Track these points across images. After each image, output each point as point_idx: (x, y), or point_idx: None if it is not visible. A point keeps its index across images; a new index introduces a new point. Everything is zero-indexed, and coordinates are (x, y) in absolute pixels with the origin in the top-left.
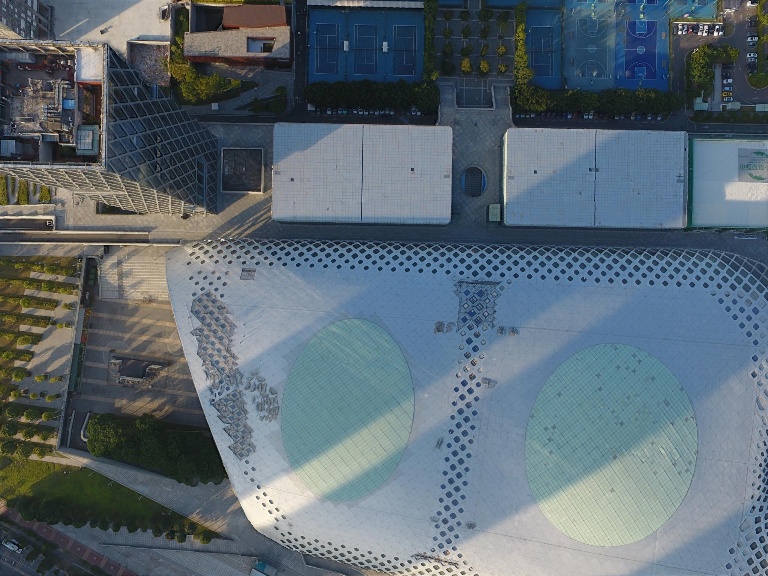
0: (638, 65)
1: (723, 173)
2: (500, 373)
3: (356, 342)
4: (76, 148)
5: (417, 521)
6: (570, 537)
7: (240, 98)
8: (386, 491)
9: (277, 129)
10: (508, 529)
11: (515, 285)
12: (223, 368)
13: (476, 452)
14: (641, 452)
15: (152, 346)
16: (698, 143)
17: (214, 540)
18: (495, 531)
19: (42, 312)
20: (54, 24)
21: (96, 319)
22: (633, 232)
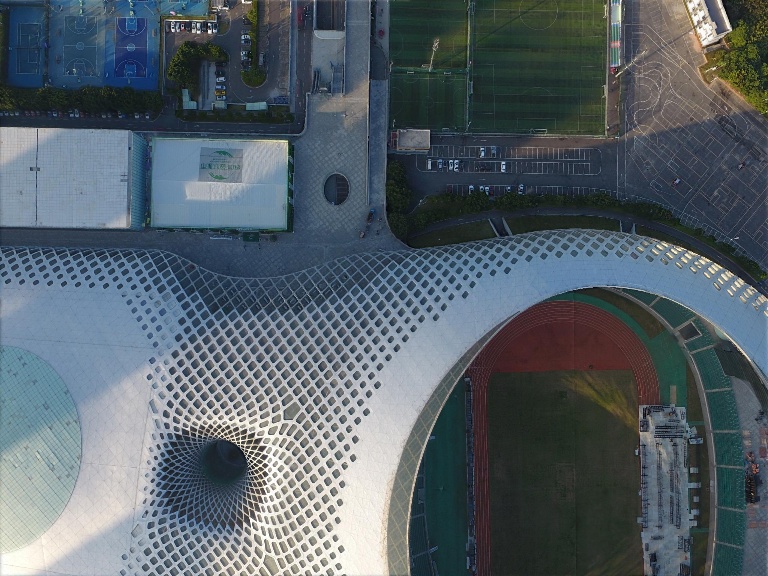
0: (128, 63)
1: (184, 172)
2: None
3: None
4: None
5: None
6: None
7: None
8: None
9: None
10: None
11: None
12: None
13: None
14: (14, 457)
15: None
16: (160, 142)
17: None
18: None
19: None
20: None
21: None
22: (106, 232)
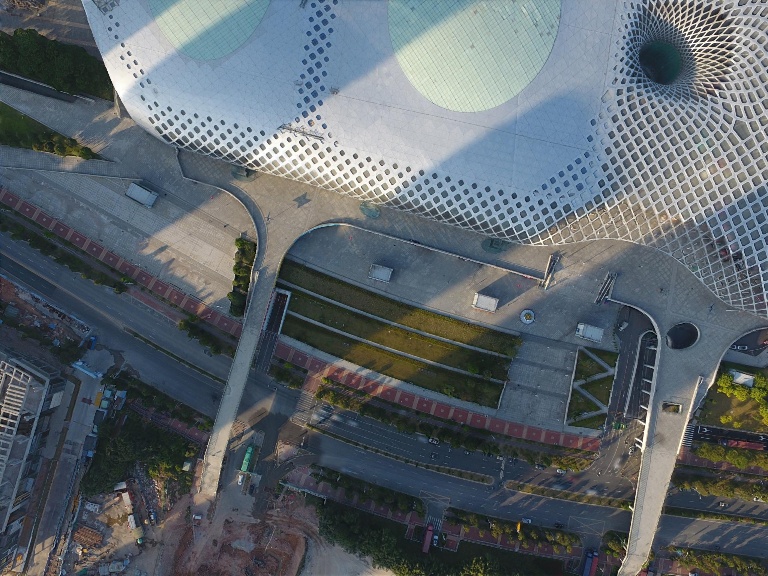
0: None
1: None
2: None
3: None
4: None
5: (281, 85)
6: (432, 102)
7: None
8: (249, 50)
9: None
10: (371, 94)
11: None
12: None
13: (340, 13)
14: (502, 9)
15: None
16: None
17: (96, 163)
18: (358, 97)
19: None
20: None
21: None
22: None
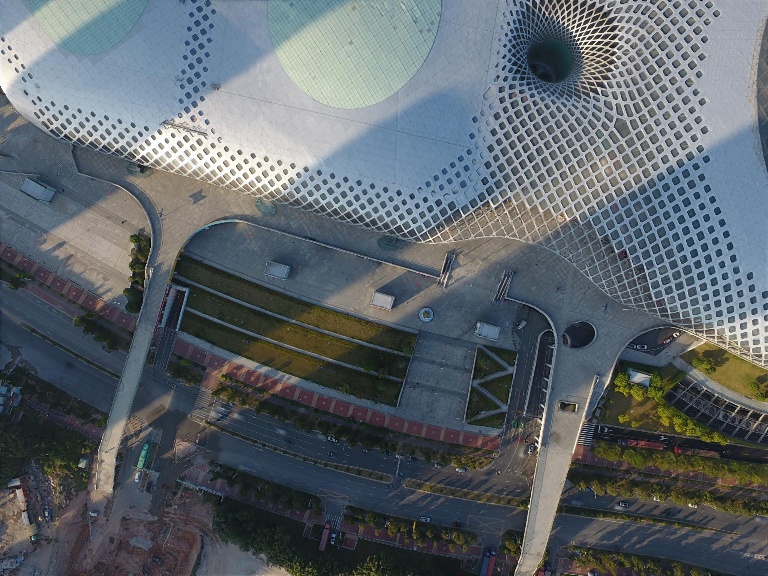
0: None
1: None
2: None
3: None
4: None
5: (162, 80)
6: (313, 98)
7: None
8: (129, 45)
9: None
10: (252, 90)
11: None
12: None
13: (221, 8)
14: (381, 5)
15: None
16: None
17: None
18: (240, 93)
19: None
20: None
21: None
22: None
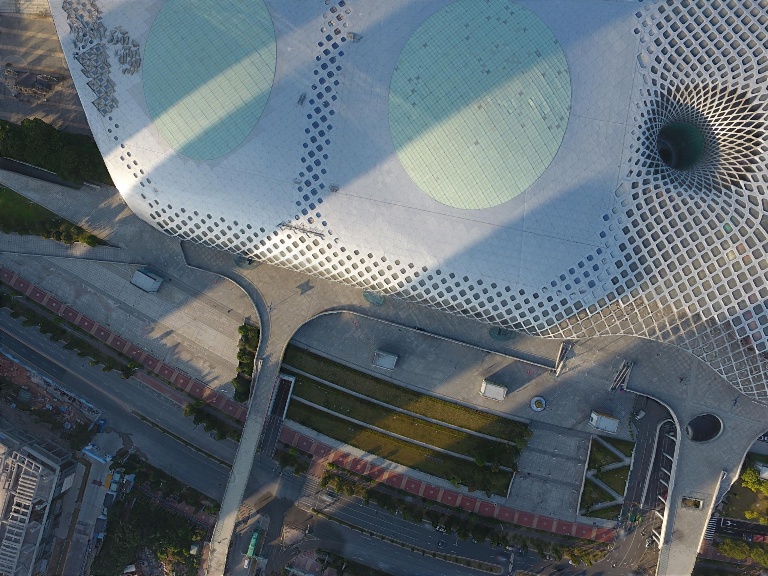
0: None
1: None
2: (366, 28)
3: None
4: None
5: (280, 183)
6: (435, 199)
7: None
8: (247, 149)
9: None
10: (372, 192)
11: None
12: (87, 22)
13: (339, 109)
14: (508, 102)
15: (47, 61)
16: None
17: (102, 248)
18: (359, 194)
19: None
20: None
21: None
22: None
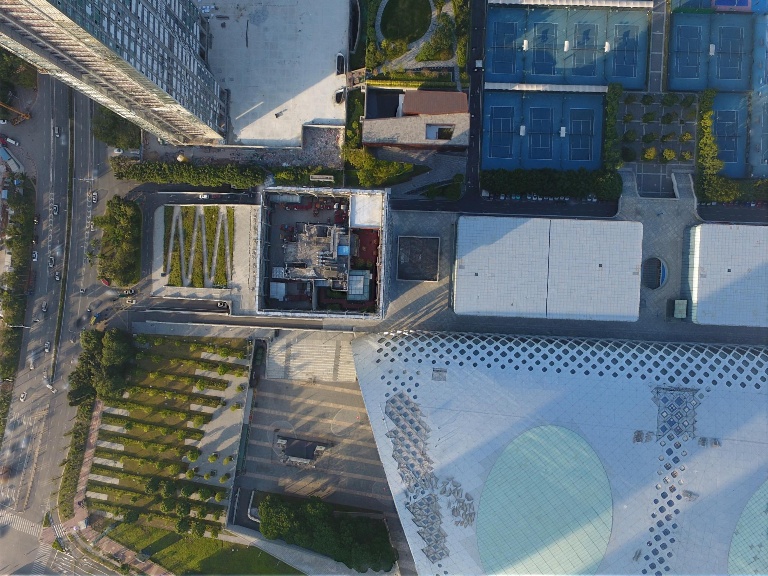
0: None
1: None
2: (702, 486)
3: (554, 450)
4: (347, 293)
5: None
6: None
7: (412, 182)
8: None
9: (462, 222)
10: None
11: (715, 393)
12: (418, 471)
13: (675, 566)
14: None
15: (316, 426)
16: None
17: None
18: None
19: (212, 392)
20: (230, 107)
21: (261, 398)
22: None
